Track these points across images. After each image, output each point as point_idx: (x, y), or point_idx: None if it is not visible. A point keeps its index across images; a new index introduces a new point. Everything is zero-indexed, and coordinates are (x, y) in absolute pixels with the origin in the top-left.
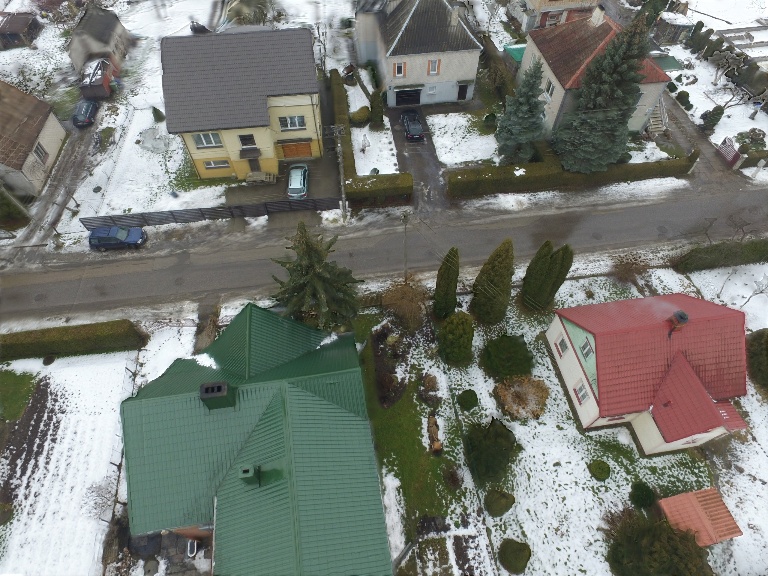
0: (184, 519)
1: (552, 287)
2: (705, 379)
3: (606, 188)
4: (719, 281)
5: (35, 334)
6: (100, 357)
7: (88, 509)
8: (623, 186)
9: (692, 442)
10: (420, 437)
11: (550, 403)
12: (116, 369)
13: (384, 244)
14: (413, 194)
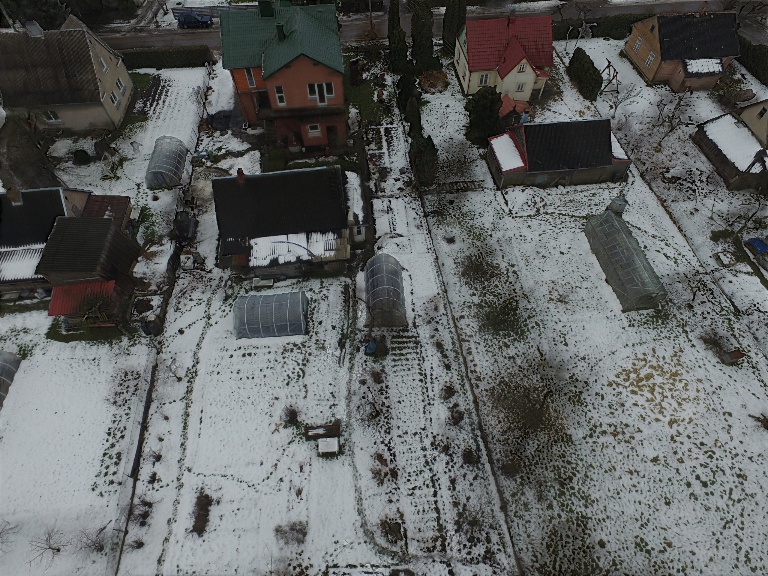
0: (248, 64)
1: (457, 30)
2: (529, 54)
3: (512, 5)
4: (569, 44)
5: (153, 48)
6: (189, 68)
7: (193, 100)
8: (523, 4)
9: (521, 91)
10: (372, 97)
11: (450, 87)
12: (199, 72)
13: (362, 28)
14: (384, 7)
